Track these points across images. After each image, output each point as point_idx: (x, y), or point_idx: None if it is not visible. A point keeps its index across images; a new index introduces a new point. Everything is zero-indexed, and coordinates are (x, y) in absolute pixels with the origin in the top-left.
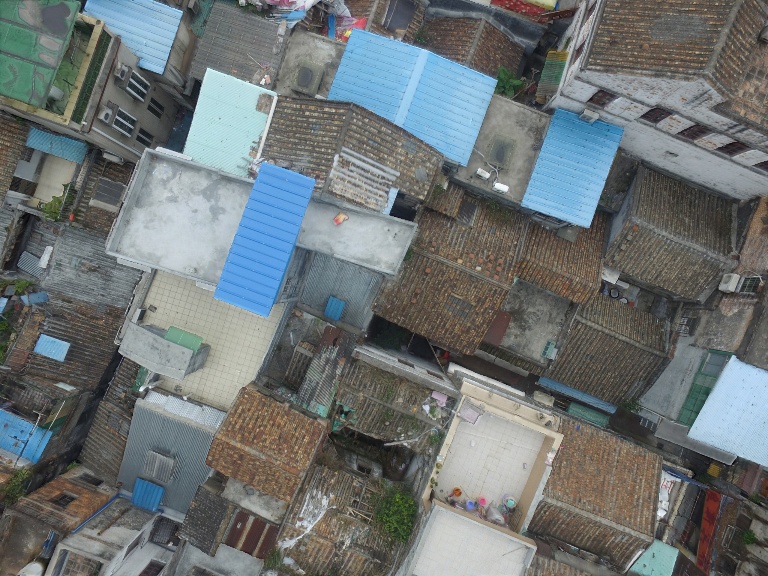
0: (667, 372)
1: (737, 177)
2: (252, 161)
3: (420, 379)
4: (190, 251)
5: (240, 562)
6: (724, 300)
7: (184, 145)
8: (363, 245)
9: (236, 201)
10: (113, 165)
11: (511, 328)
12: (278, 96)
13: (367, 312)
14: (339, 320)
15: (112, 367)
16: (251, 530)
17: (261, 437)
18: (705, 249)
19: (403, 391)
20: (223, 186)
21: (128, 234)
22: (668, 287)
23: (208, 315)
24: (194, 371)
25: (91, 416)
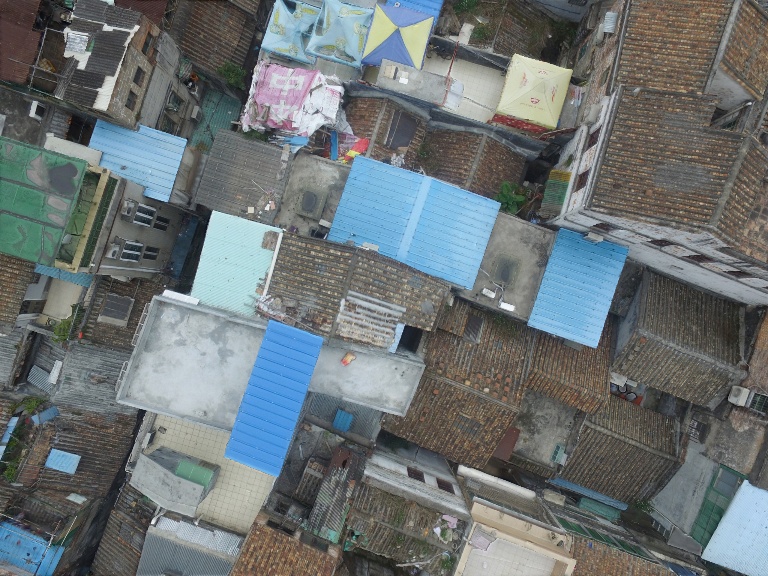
0: (678, 477)
1: (744, 291)
2: (259, 298)
3: (430, 503)
4: (199, 394)
5: None
6: (734, 412)
7: None
8: (371, 384)
9: (244, 343)
10: None
11: (520, 432)
12: (283, 232)
13: (375, 424)
14: (348, 430)
15: (122, 466)
16: None
17: None
18: (713, 360)
19: (414, 513)
20: (231, 328)
21: (138, 378)
22: (677, 394)
23: (217, 435)
24: (205, 497)
25: (102, 514)
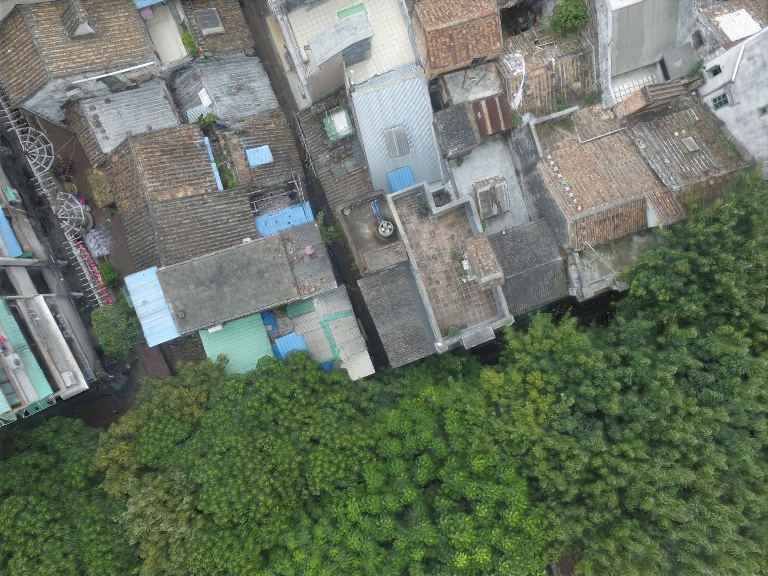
0: None
1: None
2: None
3: None
4: None
5: (494, 169)
6: None
7: None
8: None
9: None
10: (195, 0)
11: None
12: None
13: None
14: None
15: None
16: (489, 112)
17: (453, 15)
18: None
19: None
20: None
21: None
22: None
23: None
24: None
25: None
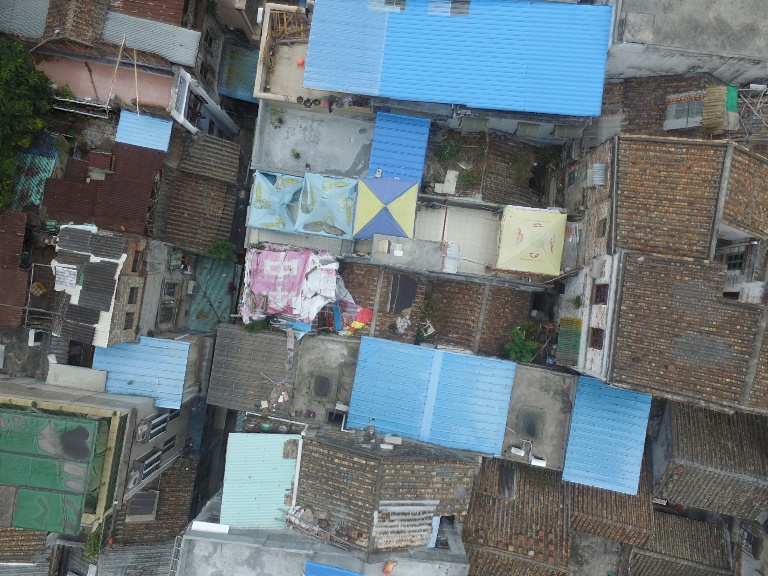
0: None
1: None
2: (288, 510)
3: None
4: None
5: None
6: None
7: (219, 514)
8: None
9: (281, 565)
10: None
11: None
12: (303, 438)
13: None
14: None
15: None
16: None
17: None
18: (755, 478)
19: None
20: (266, 552)
21: None
22: (723, 512)
23: None
24: None
25: None
